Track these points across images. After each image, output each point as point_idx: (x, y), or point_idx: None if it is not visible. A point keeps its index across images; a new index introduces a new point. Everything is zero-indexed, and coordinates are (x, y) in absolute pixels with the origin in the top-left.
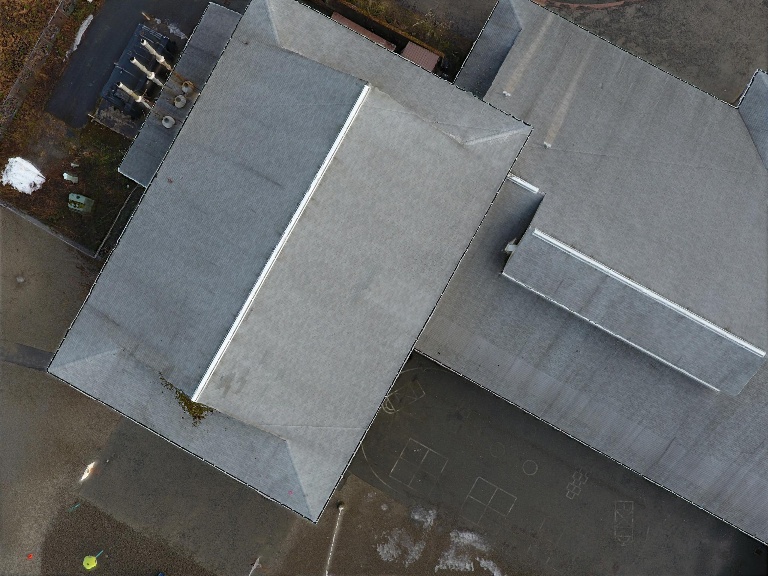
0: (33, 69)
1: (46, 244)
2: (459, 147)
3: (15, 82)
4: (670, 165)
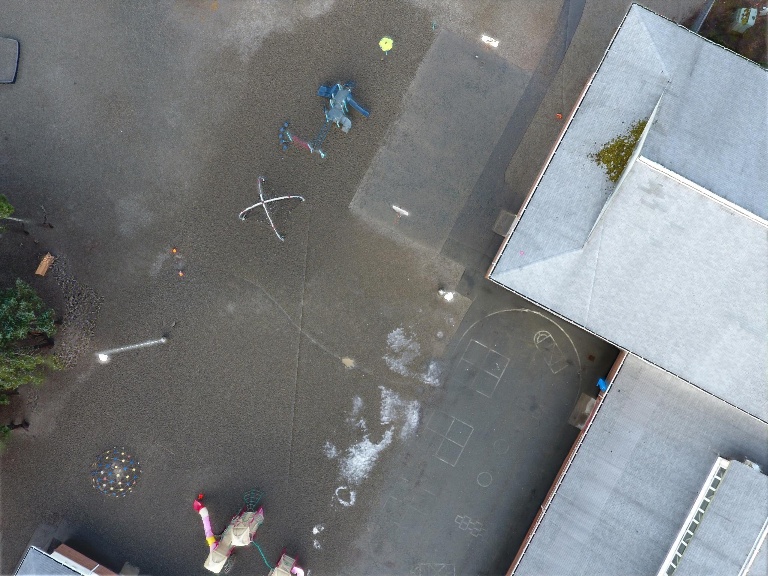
0: None
1: None
2: None
3: None
4: None
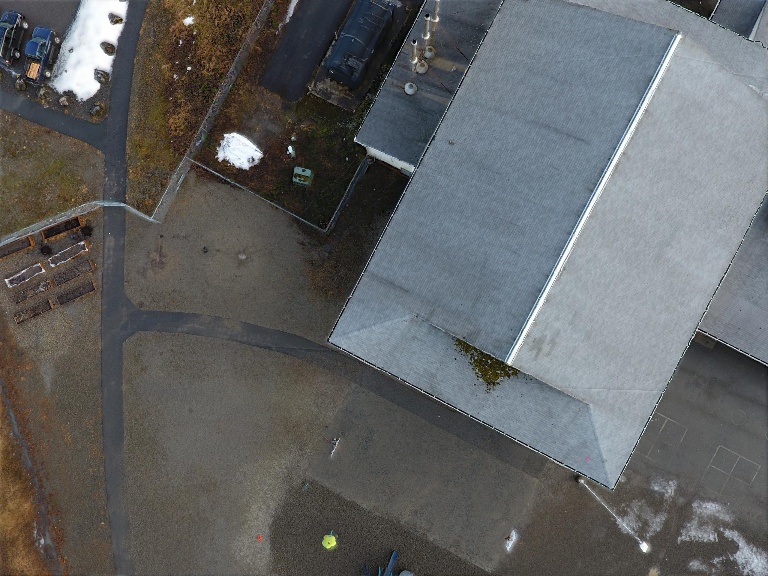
0: (248, 42)
1: (267, 220)
2: (759, 98)
3: (237, 55)
4: None
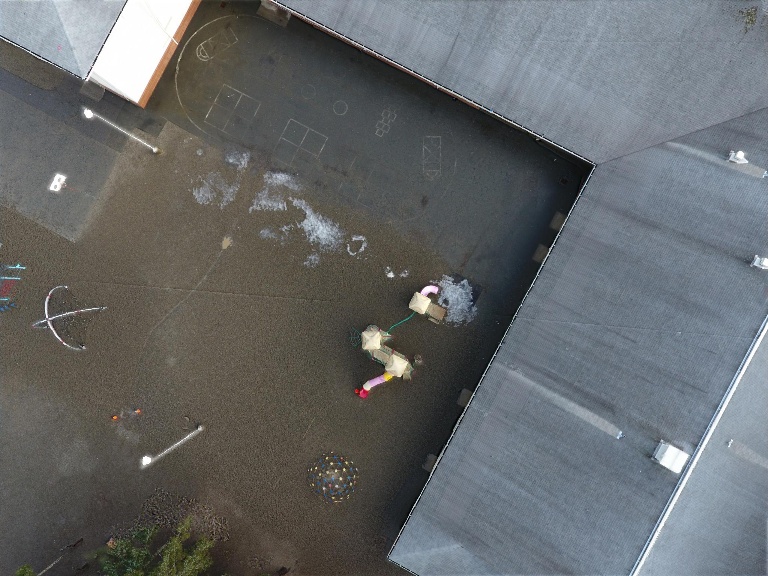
0: None
1: None
2: None
3: None
4: None
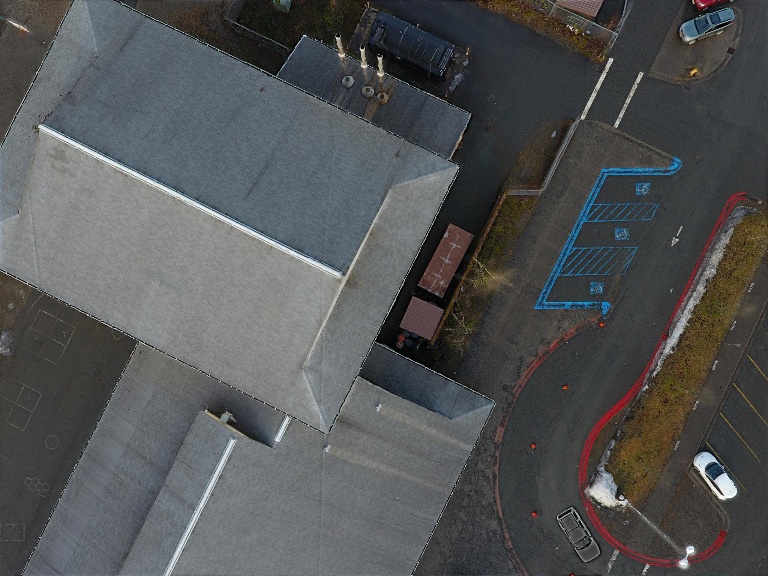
0: None
1: None
2: (299, 364)
3: None
4: (317, 567)
